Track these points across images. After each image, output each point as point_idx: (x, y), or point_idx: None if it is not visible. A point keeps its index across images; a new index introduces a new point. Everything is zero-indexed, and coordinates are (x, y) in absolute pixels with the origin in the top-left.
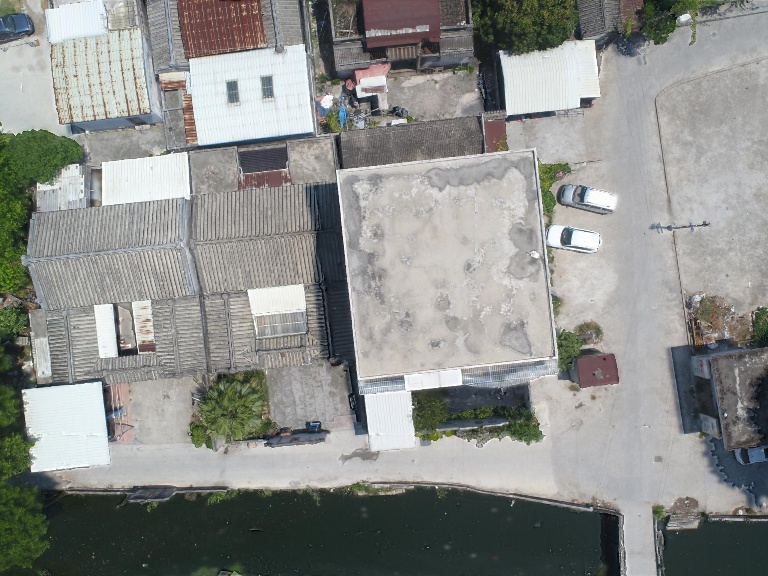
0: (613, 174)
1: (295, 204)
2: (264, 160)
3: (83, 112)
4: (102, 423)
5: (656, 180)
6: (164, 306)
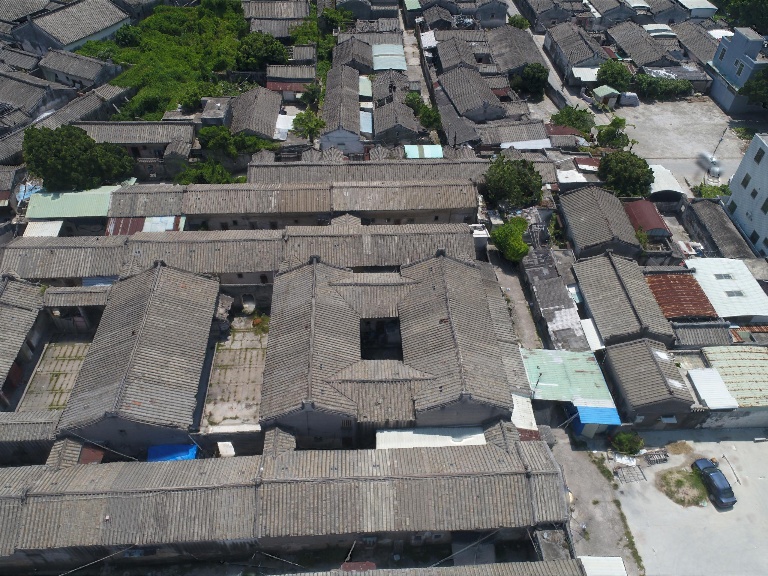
0: (690, 174)
1: None
2: (767, 293)
3: None
4: None
5: (687, 161)
6: None
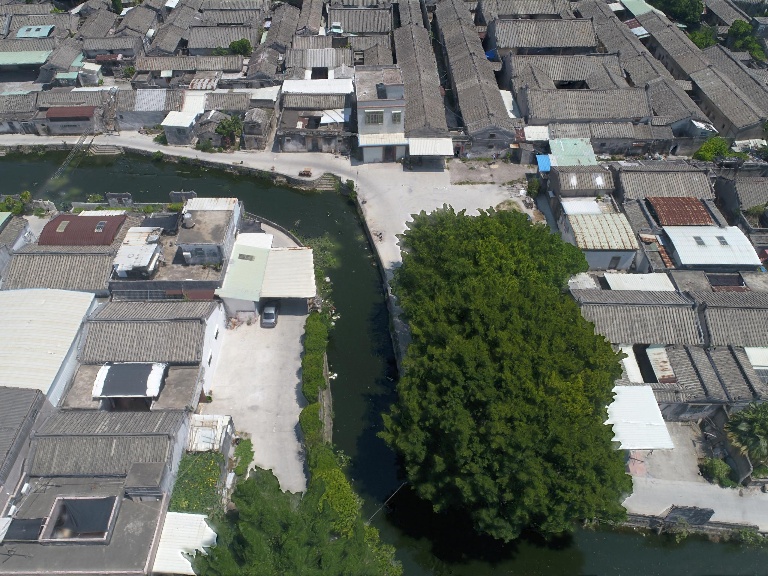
0: None
1: (766, 298)
2: (725, 281)
3: (594, 244)
4: (658, 415)
5: None
6: (679, 350)
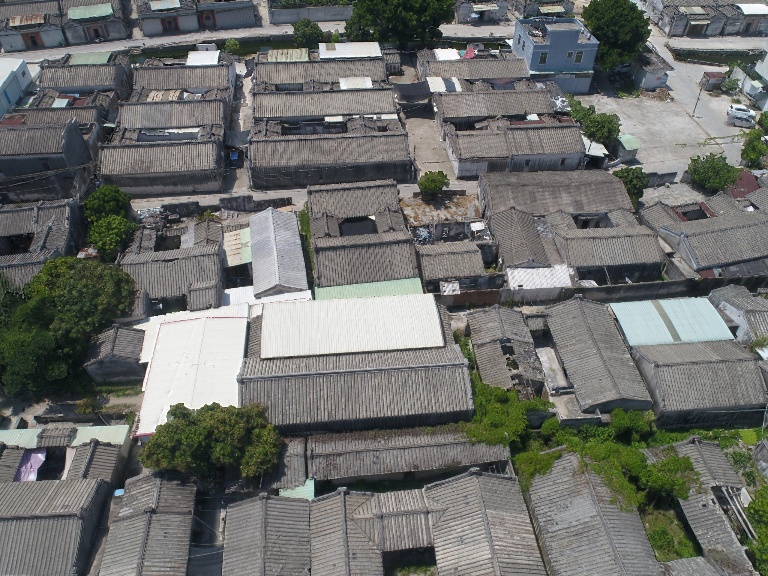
0: (731, 131)
1: None
2: None
3: None
4: None
5: None
6: None
